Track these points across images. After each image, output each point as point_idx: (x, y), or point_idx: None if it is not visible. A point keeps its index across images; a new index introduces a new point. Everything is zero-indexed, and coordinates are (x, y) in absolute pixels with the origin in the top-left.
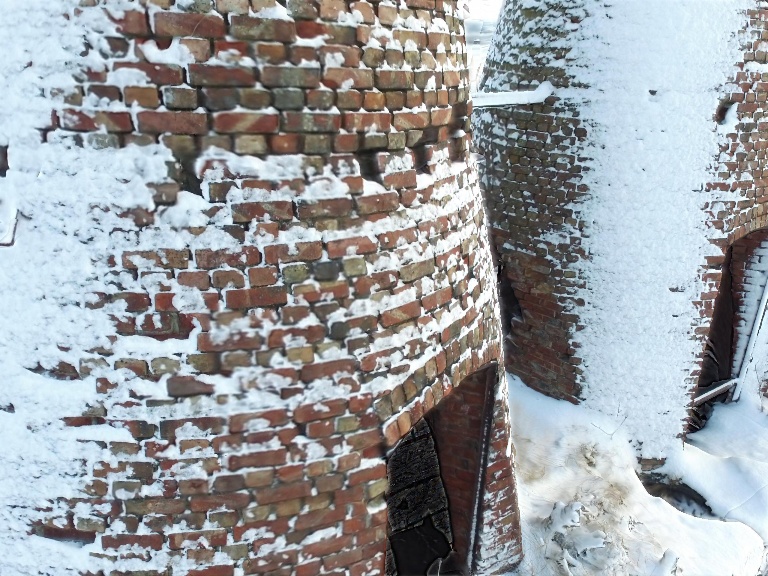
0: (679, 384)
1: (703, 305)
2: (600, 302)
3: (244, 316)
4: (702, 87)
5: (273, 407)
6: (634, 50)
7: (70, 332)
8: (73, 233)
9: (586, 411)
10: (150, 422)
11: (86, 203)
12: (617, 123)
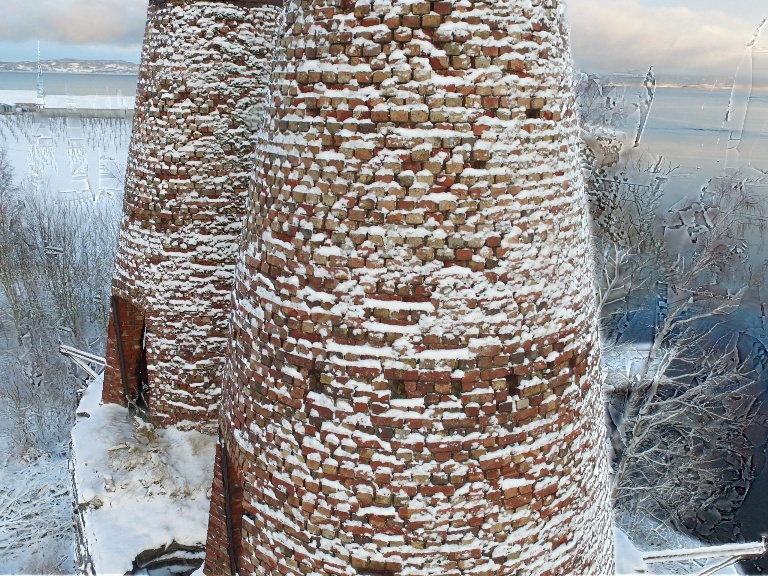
0: None
1: None
2: None
3: None
4: None
5: None
6: None
7: None
8: None
9: None
10: None
11: None
12: None
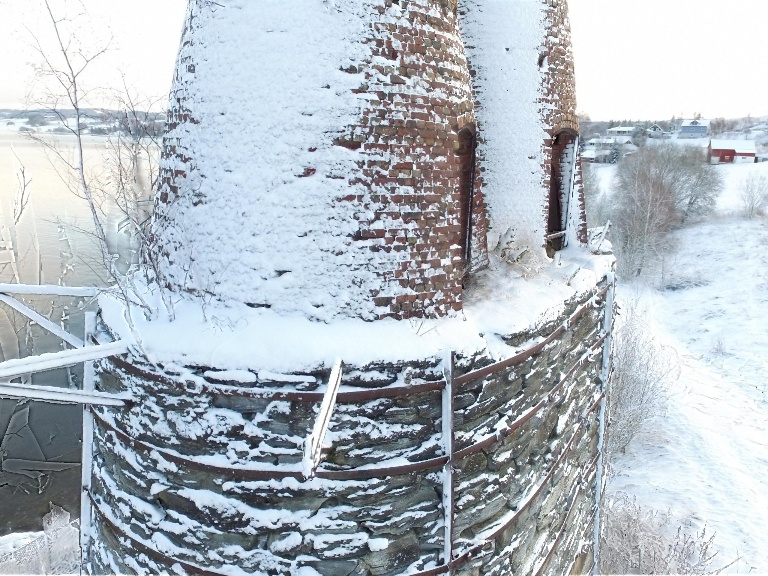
0: (540, 214)
1: (546, 167)
2: (494, 168)
3: (414, 55)
4: (530, 47)
5: (424, 95)
6: (496, 27)
7: (355, 53)
8: (357, 14)
9: (494, 234)
10: (385, 92)
11: (362, 2)
12: (492, 66)
